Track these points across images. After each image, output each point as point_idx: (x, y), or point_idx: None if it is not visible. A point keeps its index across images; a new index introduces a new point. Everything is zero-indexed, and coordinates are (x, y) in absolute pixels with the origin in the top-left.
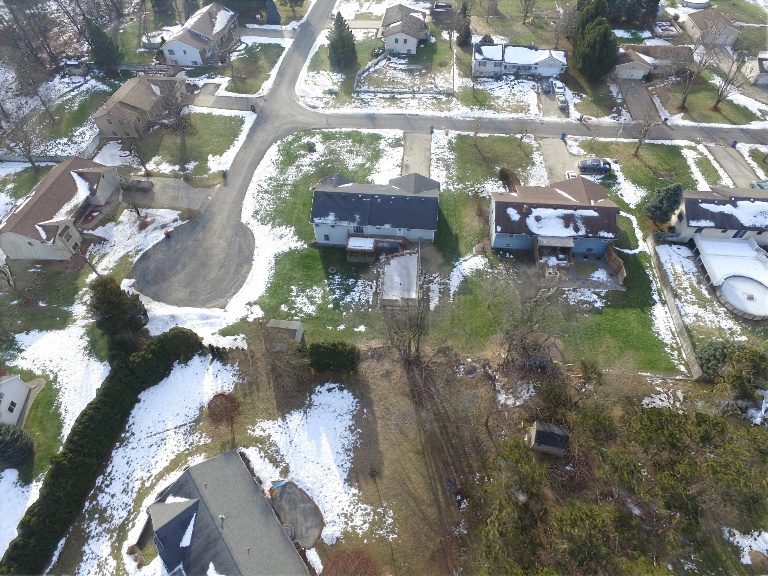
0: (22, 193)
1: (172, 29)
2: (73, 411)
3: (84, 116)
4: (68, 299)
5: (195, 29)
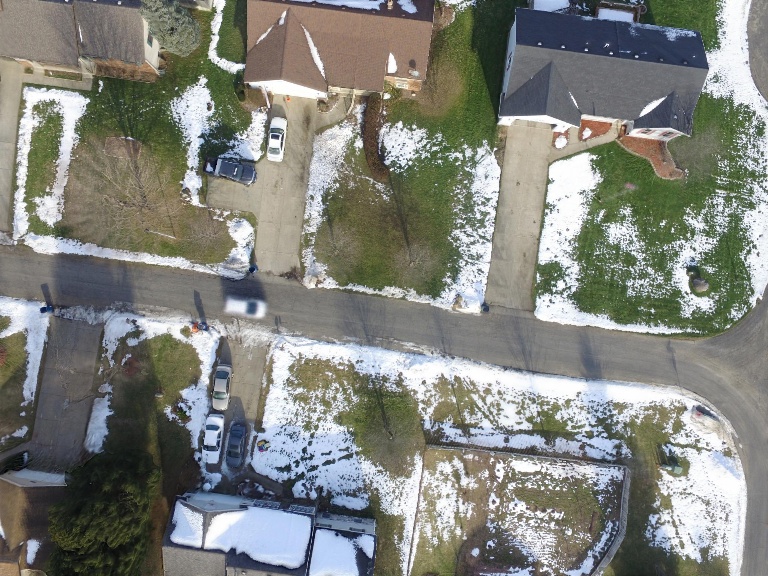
0: None
1: None
2: None
3: None
4: None
5: None
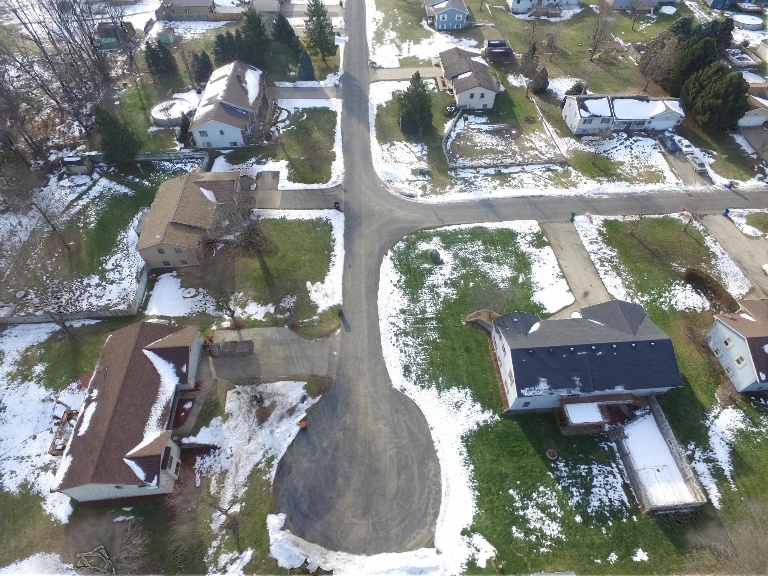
0: (63, 380)
1: (186, 97)
2: None
3: (110, 237)
4: (195, 566)
5: (229, 101)
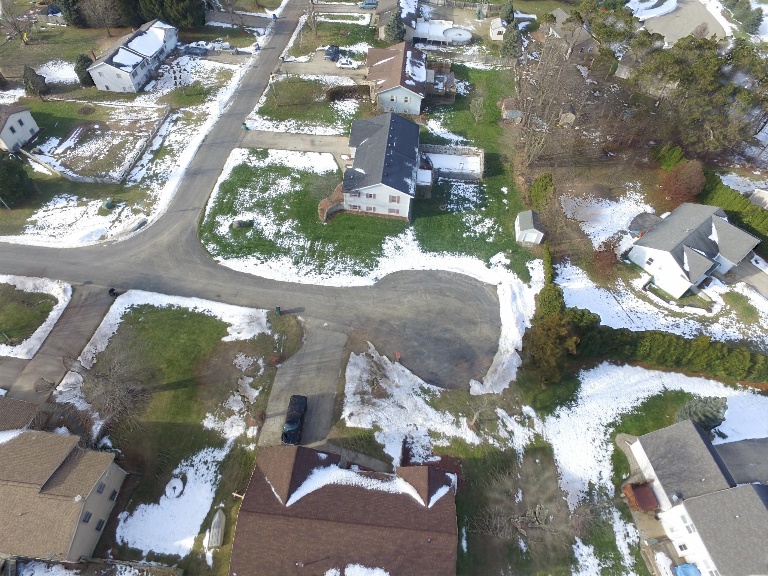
0: None
1: None
2: (636, 392)
3: None
4: (508, 459)
5: None
